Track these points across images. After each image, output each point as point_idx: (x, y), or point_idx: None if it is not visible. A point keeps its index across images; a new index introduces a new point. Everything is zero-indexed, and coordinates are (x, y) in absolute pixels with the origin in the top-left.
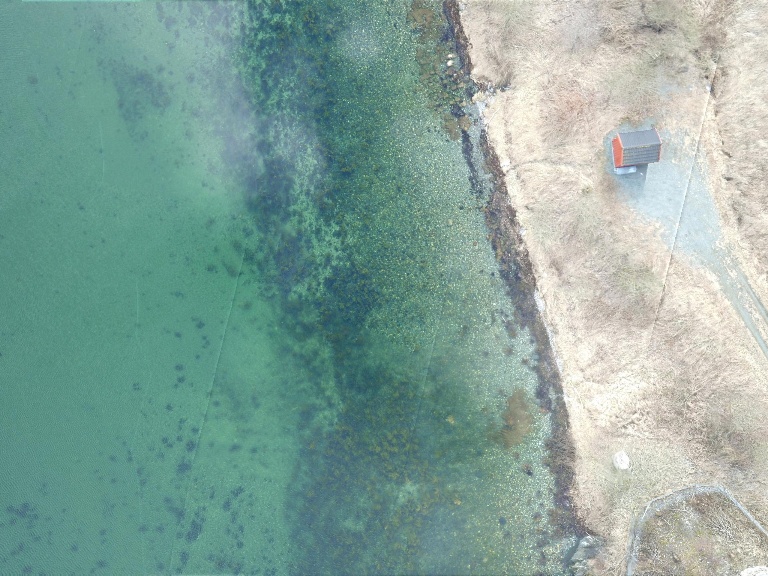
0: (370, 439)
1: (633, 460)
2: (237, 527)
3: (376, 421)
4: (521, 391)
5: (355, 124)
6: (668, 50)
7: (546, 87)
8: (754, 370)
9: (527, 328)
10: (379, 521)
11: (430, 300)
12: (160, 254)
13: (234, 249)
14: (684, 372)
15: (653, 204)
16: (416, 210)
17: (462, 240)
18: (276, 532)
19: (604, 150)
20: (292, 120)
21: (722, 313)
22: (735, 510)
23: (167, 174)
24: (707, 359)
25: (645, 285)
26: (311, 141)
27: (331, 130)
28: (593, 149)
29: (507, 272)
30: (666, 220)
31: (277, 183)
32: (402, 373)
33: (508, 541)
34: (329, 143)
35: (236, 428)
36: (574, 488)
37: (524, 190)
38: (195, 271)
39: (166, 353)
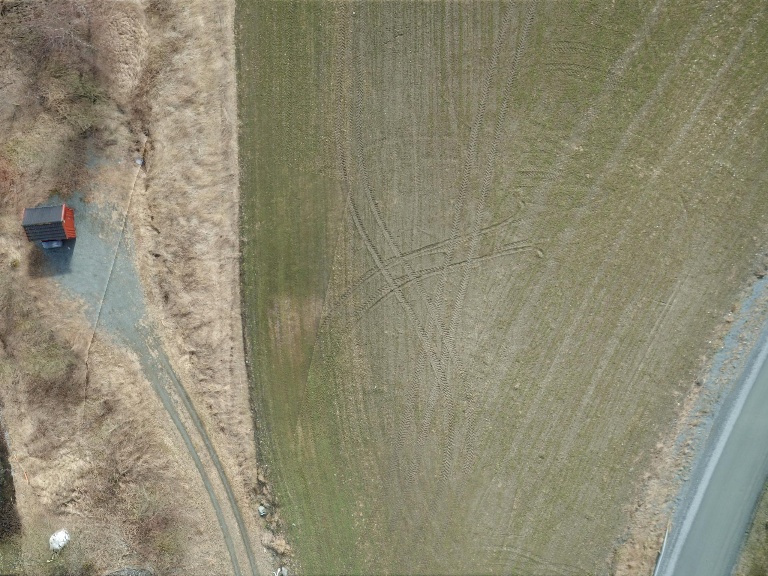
0: None
1: (72, 539)
2: None
3: None
4: None
5: None
6: (98, 122)
7: None
8: (173, 453)
9: None
10: None
11: None
12: None
13: None
14: (113, 452)
15: (78, 280)
16: None
17: None
18: None
19: None
20: None
21: (141, 394)
22: None
23: None
24: (130, 440)
25: (72, 362)
26: None
27: None
28: None
29: None
30: (90, 296)
31: None
32: None
33: None
34: None
35: None
36: (19, 565)
37: None
38: None
39: None
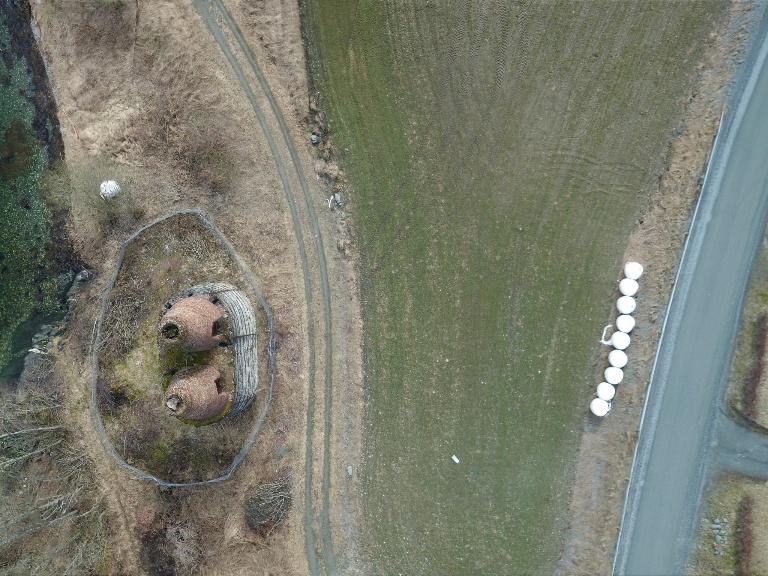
0: None
1: (122, 189)
2: None
3: None
4: (19, 123)
5: None
6: None
7: None
8: (224, 86)
9: (24, 58)
10: None
11: None
12: None
13: None
14: (163, 93)
15: None
16: None
17: None
18: None
19: None
20: None
21: (192, 27)
22: (212, 233)
23: None
24: (181, 77)
25: (121, 2)
26: None
27: None
28: None
29: None
30: None
31: None
32: None
33: (6, 277)
34: None
35: None
36: (69, 221)
37: None
38: None
39: None
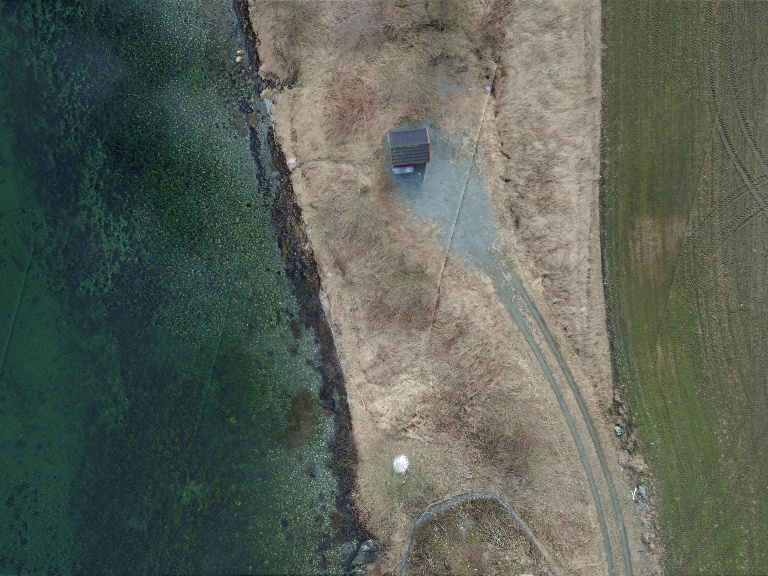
0: (155, 437)
1: (412, 464)
2: (21, 523)
3: (160, 419)
4: (305, 391)
5: (144, 119)
6: (448, 49)
7: (330, 85)
8: (527, 375)
9: (312, 328)
10: (161, 520)
11: (216, 298)
12: None
13: (23, 243)
14: (461, 375)
15: (430, 205)
16: (204, 207)
17: (249, 238)
18: (60, 529)
19: (383, 149)
20: (82, 114)
21: (495, 316)
22: (509, 517)
23: None
24: (481, 363)
25: (421, 286)
26: (101, 135)
27: (121, 125)
28: (372, 148)
29: (292, 271)
30: (442, 221)
31: (66, 177)
32: (188, 371)
33: (290, 543)
34: (117, 138)
35: (21, 423)
36: (355, 491)
37: (309, 188)
38: None
39: None
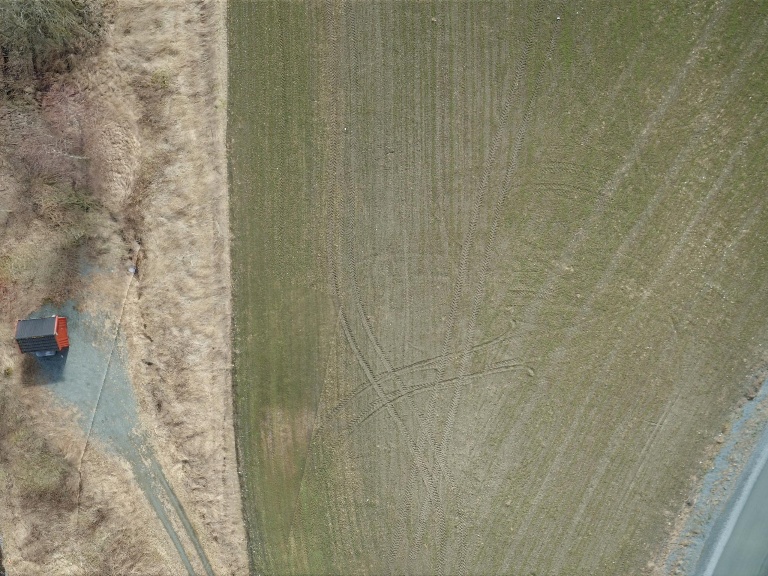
0: None
1: None
2: None
3: None
4: None
5: None
6: (91, 230)
7: None
8: (166, 562)
9: None
10: None
11: None
12: None
13: None
14: (106, 559)
15: (72, 388)
16: None
17: None
18: None
19: None
20: None
21: (134, 503)
22: None
23: None
24: (123, 548)
25: (65, 470)
26: None
27: None
28: None
29: None
30: (83, 405)
31: None
32: None
33: None
34: None
35: None
36: None
37: None
38: None
39: None
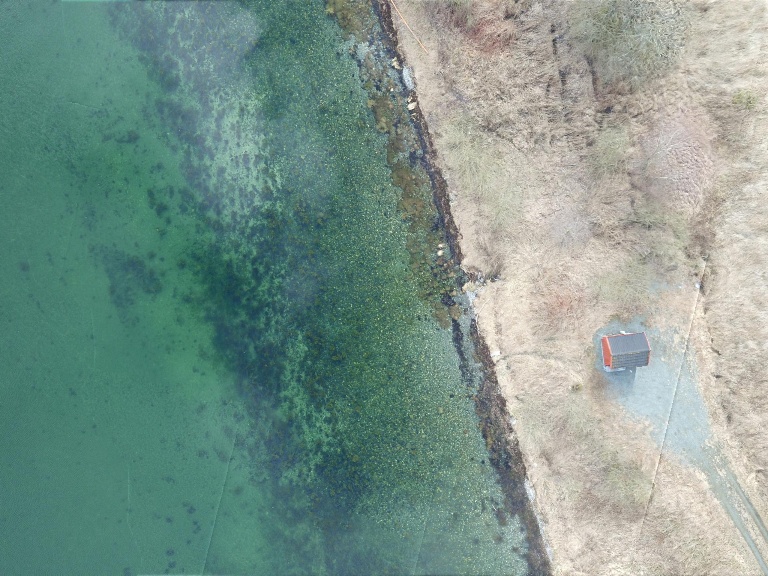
0: None
1: None
2: None
3: None
4: None
5: (346, 312)
6: (657, 248)
7: (536, 280)
8: (743, 569)
9: (517, 516)
10: None
11: (420, 487)
12: (151, 440)
13: (225, 434)
14: (674, 567)
15: (642, 402)
16: (406, 398)
17: (452, 428)
18: None
19: (594, 347)
20: (283, 307)
21: (711, 512)
22: None
23: (158, 360)
24: (696, 557)
25: (634, 482)
26: (302, 328)
27: (322, 317)
28: (583, 346)
29: (497, 461)
30: (655, 418)
31: (268, 370)
32: (393, 559)
33: None
34: (320, 332)
35: None
36: None
37: (514, 381)
38: (186, 457)
39: (157, 539)
